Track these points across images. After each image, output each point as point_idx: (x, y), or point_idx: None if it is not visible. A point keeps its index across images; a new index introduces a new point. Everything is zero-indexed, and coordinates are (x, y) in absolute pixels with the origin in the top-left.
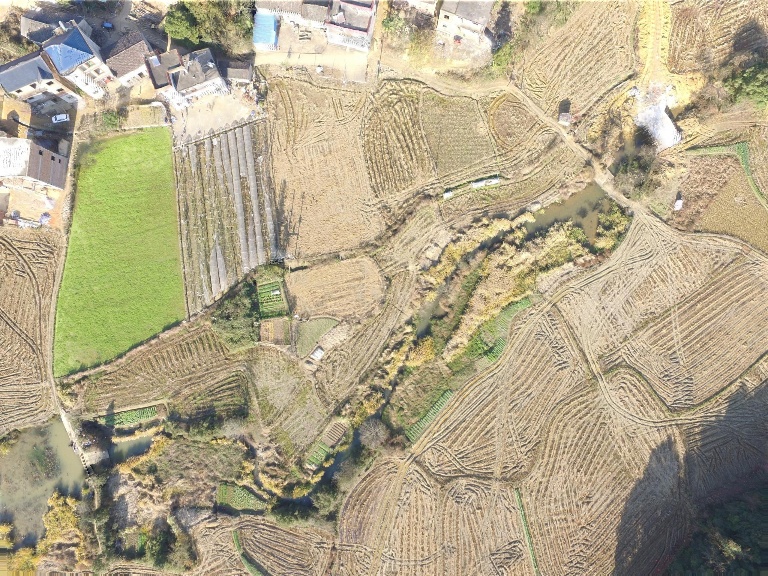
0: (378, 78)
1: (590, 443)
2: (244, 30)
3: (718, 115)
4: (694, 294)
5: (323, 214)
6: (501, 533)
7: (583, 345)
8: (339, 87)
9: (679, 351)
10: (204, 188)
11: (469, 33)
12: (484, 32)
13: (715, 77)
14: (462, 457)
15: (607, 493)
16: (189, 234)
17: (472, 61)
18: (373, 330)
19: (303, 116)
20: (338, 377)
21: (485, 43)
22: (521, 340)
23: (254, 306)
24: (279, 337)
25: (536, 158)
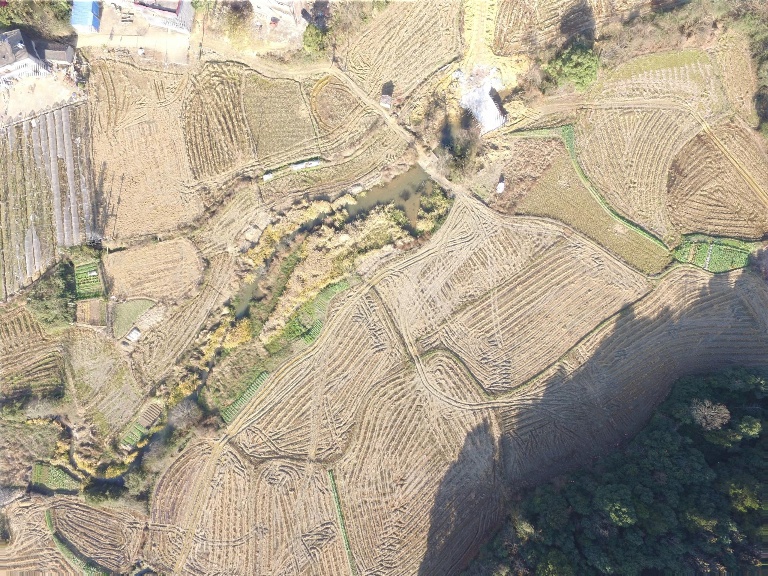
0: (200, 60)
1: (405, 425)
2: (63, 12)
3: (544, 98)
4: (514, 277)
5: (142, 196)
6: (314, 515)
7: (401, 327)
8: (161, 69)
9: (497, 334)
10: (24, 169)
11: (283, 14)
12: (302, 14)
13: (541, 59)
14: (277, 439)
15: (421, 476)
16: (8, 215)
17: (289, 43)
18: (191, 311)
19: (125, 98)
20: (155, 358)
21: (302, 25)
22: (339, 322)
23: (70, 287)
24: (95, 318)
25: (357, 140)
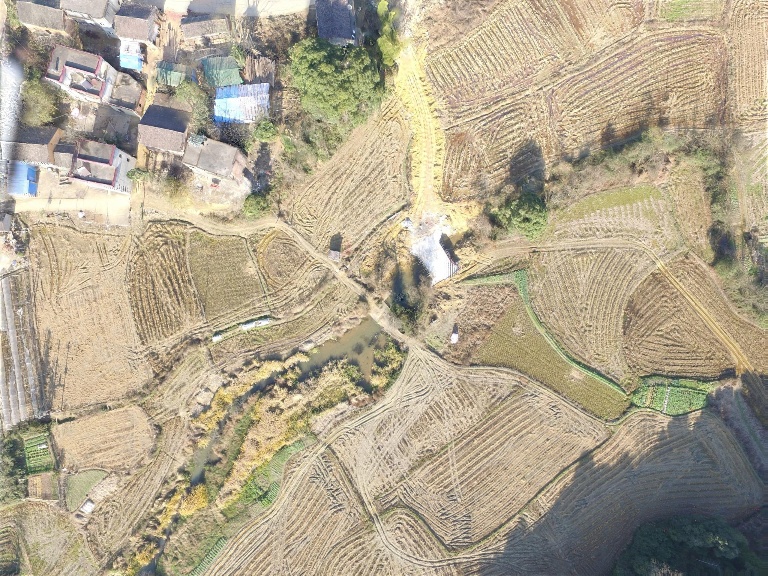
0: (143, 220)
1: None
2: None
3: (496, 242)
4: (471, 429)
5: (89, 364)
6: None
7: (358, 486)
8: (103, 232)
9: (456, 489)
10: None
11: (223, 178)
12: (243, 173)
13: (492, 203)
14: None
15: None
16: None
17: (232, 204)
18: (145, 479)
19: (67, 263)
20: (110, 529)
21: (244, 184)
22: (295, 484)
23: (19, 462)
24: (47, 492)
25: (307, 296)
